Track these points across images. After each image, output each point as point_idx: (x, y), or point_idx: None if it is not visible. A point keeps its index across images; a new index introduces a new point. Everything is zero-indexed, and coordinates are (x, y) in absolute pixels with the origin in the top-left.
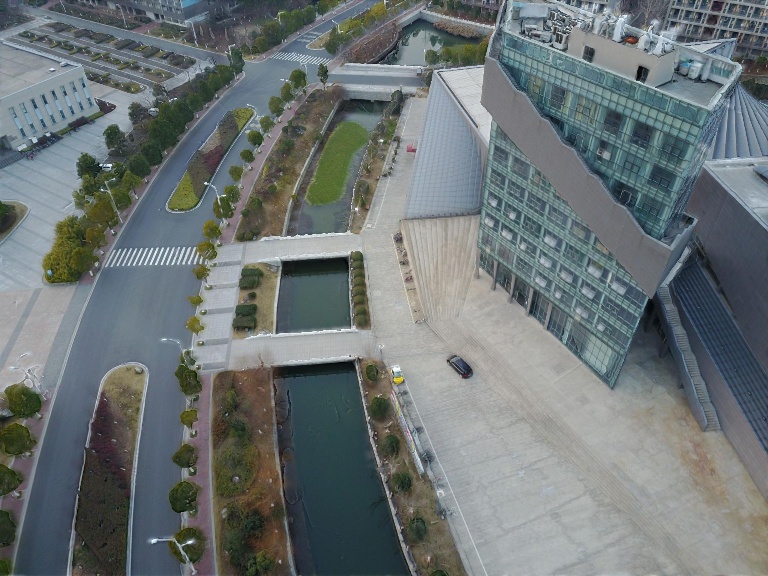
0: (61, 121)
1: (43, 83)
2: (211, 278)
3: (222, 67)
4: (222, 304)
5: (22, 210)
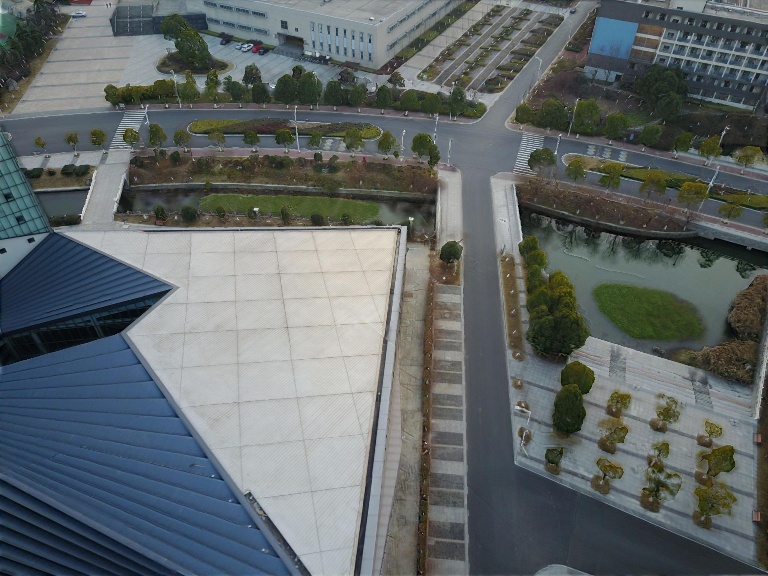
0: (343, 55)
1: (341, 20)
2: (88, 154)
3: (429, 94)
4: (52, 163)
5: (219, 73)
